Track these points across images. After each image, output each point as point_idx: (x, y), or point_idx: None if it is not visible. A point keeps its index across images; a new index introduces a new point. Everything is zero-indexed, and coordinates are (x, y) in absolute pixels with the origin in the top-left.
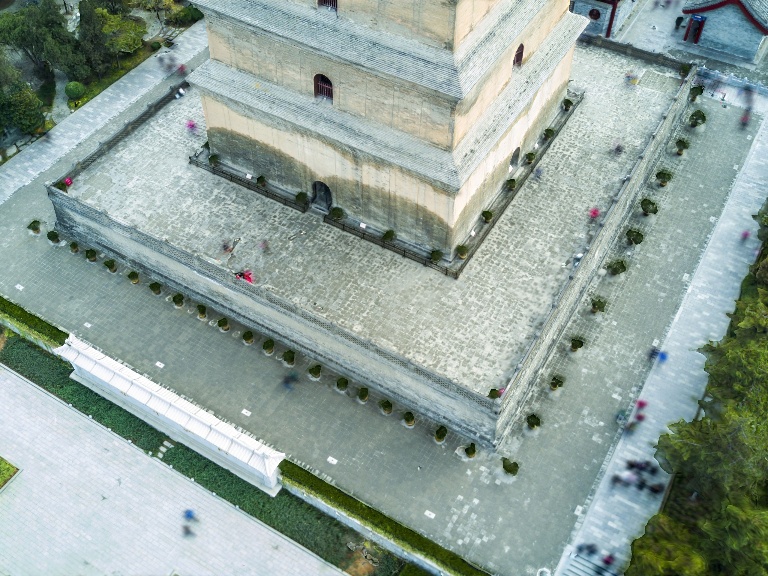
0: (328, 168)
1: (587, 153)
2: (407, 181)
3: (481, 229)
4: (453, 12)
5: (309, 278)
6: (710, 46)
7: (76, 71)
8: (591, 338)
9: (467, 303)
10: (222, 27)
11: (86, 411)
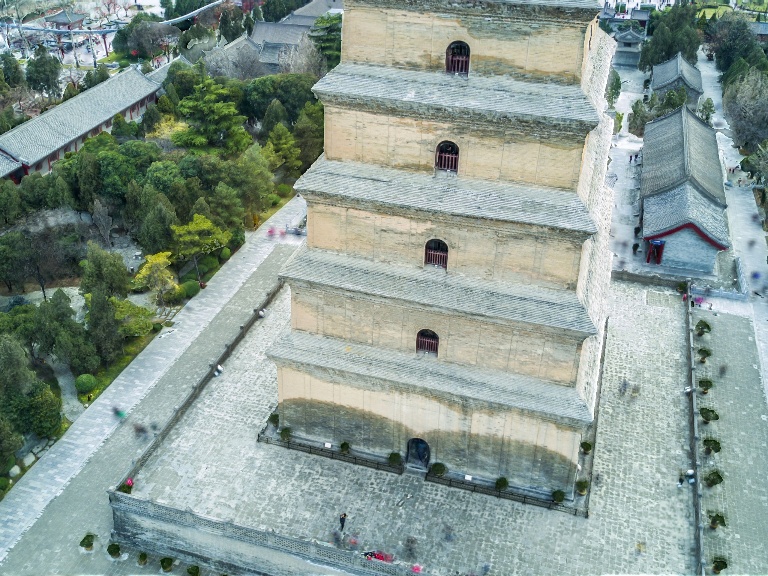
0: (429, 423)
1: (639, 372)
2: (525, 423)
3: (584, 461)
4: (578, 255)
5: (438, 545)
6: (672, 265)
7: (87, 363)
8: (725, 556)
9: (610, 541)
10: (311, 296)
11: None
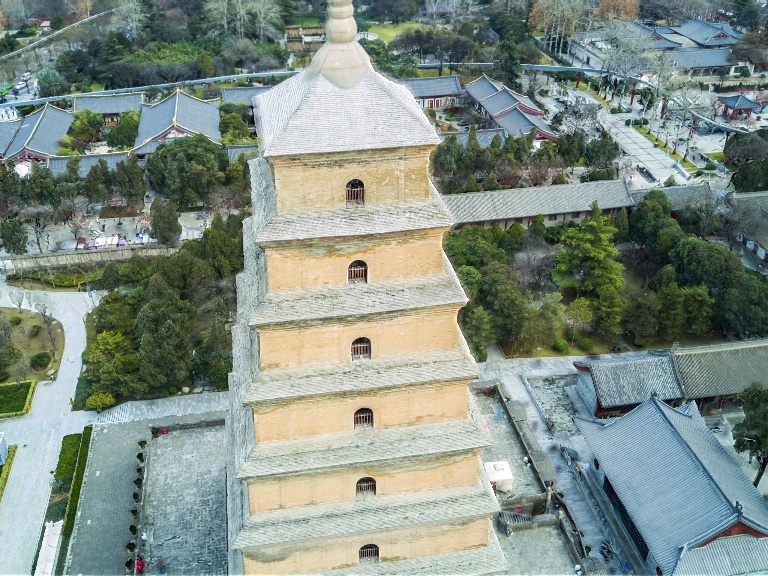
0: None
1: None
2: None
3: None
4: None
5: None
6: None
7: None
8: None
9: None
10: None
11: (33, 570)
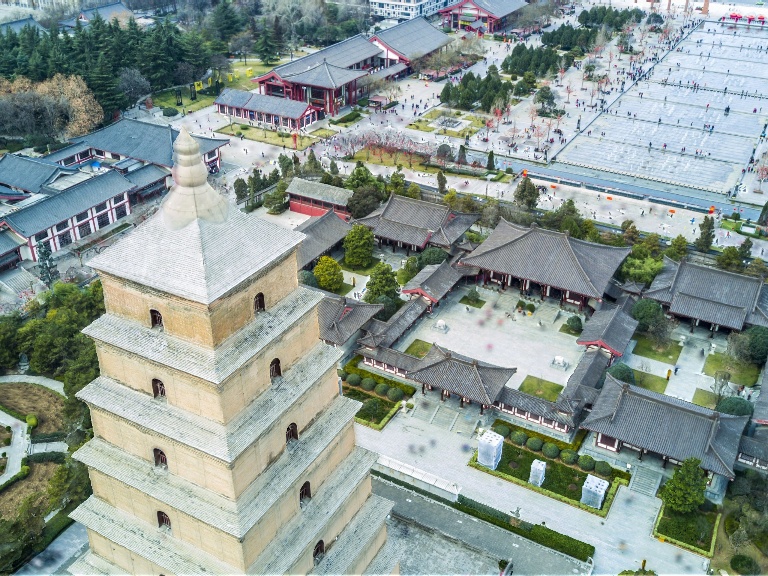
0: None
1: None
2: None
3: None
4: None
5: None
6: None
7: None
8: None
9: None
10: None
11: None
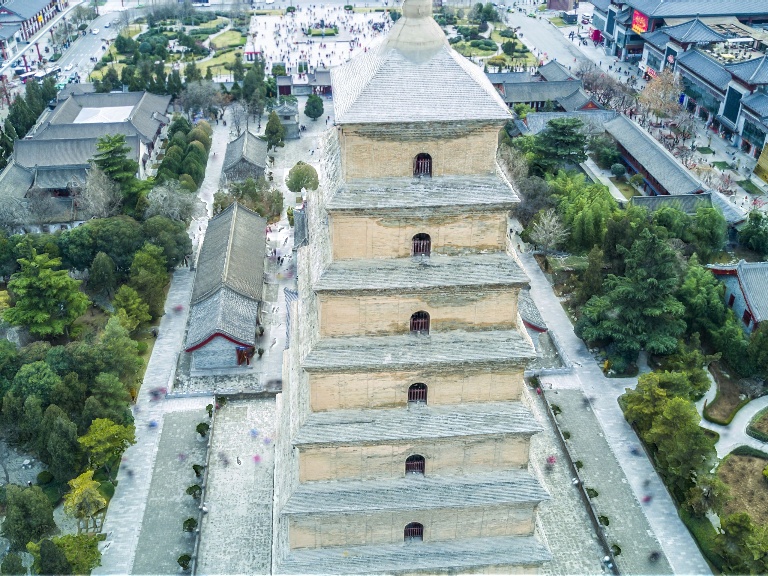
0: None
1: None
2: (500, 571)
3: None
4: (528, 445)
5: None
6: None
7: None
8: None
9: None
10: (309, 521)
11: None
